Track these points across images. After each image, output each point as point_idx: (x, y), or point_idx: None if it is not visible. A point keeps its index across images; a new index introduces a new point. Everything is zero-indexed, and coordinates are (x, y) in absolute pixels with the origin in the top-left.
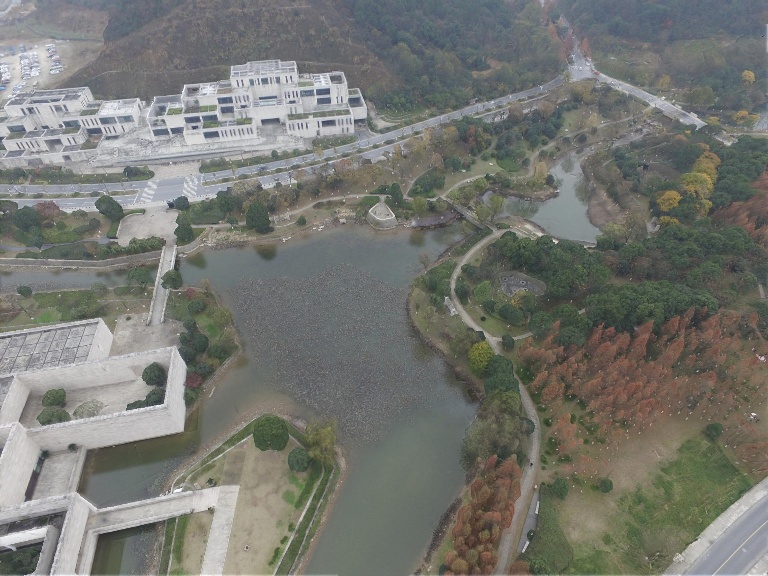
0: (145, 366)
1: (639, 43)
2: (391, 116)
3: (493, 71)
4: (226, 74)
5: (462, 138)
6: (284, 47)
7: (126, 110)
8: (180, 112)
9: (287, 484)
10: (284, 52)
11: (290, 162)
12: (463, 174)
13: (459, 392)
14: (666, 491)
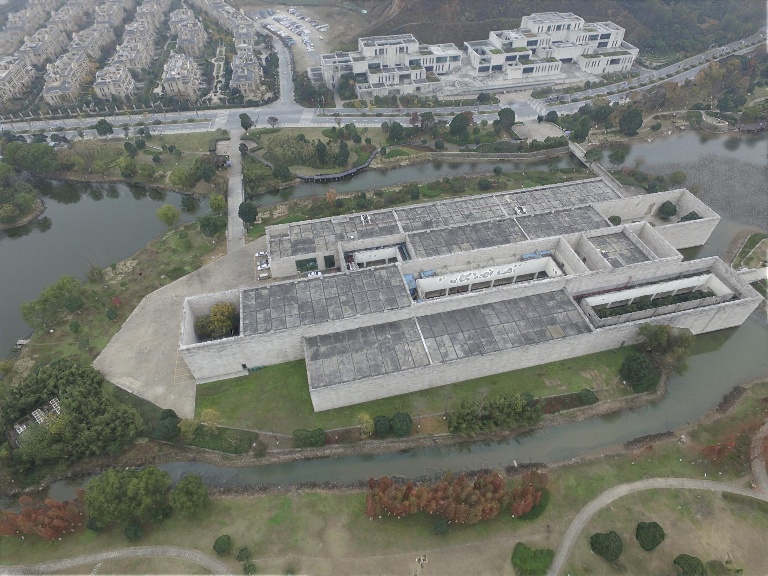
0: (659, 204)
1: None
2: (654, 57)
3: (722, 22)
4: (505, 25)
5: (743, 69)
6: (550, 3)
7: (454, 51)
8: (502, 52)
9: None
10: (551, 7)
11: (601, 90)
12: (750, 96)
13: None
14: None
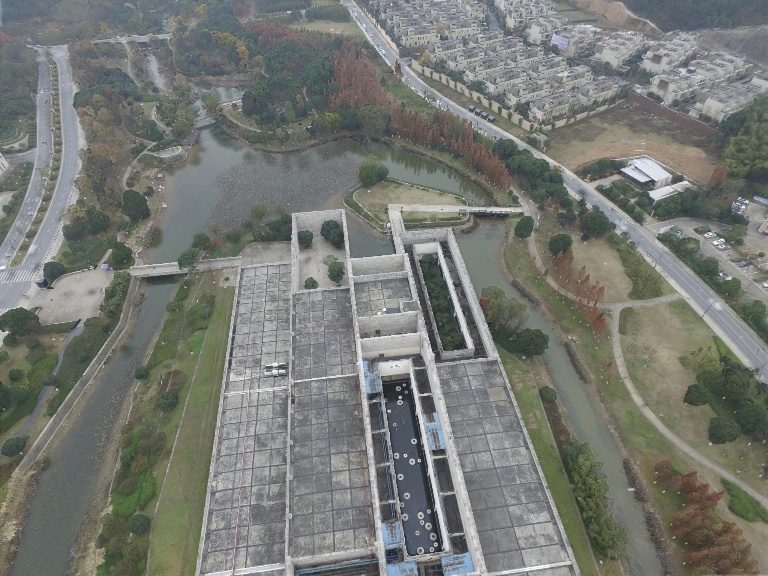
0: (297, 241)
1: (30, 20)
2: (8, 138)
3: (6, 71)
4: None
5: None
6: None
7: None
8: None
9: (390, 188)
10: None
11: (31, 203)
12: None
13: (345, 140)
14: (406, 97)
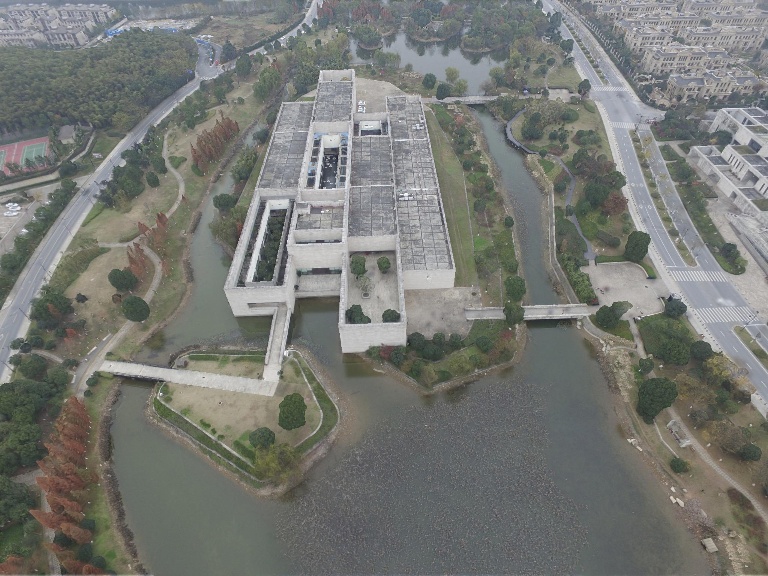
0: None
1: None
2: None
3: None
4: None
5: None
6: None
7: None
8: None
9: None
10: None
11: None
12: None
13: None
14: None
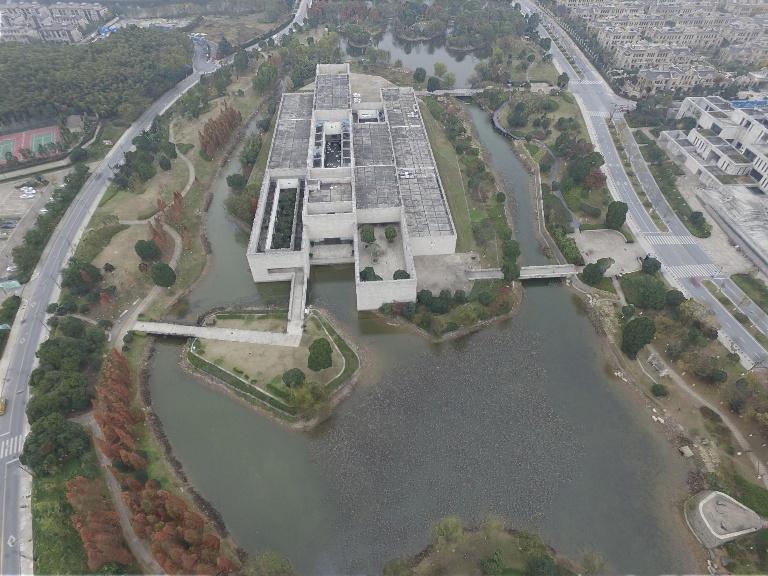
0: None
1: None
2: None
3: None
4: None
5: None
6: None
7: None
8: None
9: None
10: None
11: None
12: None
13: (348, 573)
14: None
